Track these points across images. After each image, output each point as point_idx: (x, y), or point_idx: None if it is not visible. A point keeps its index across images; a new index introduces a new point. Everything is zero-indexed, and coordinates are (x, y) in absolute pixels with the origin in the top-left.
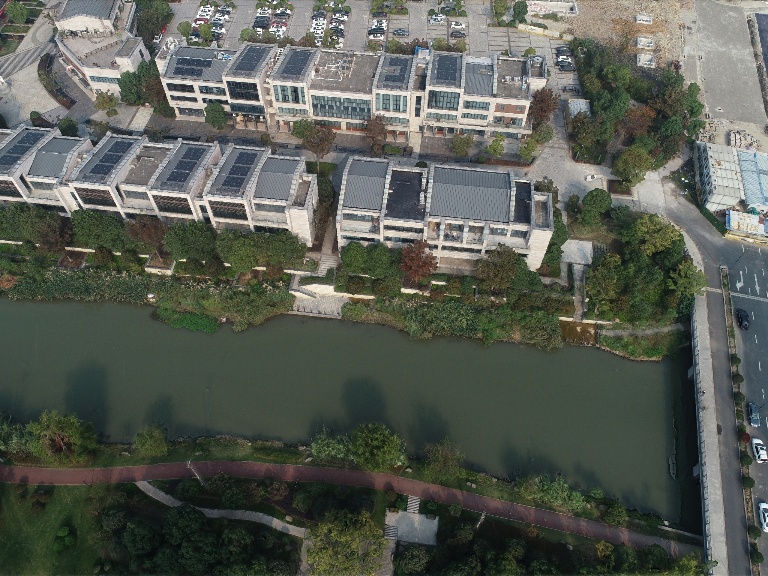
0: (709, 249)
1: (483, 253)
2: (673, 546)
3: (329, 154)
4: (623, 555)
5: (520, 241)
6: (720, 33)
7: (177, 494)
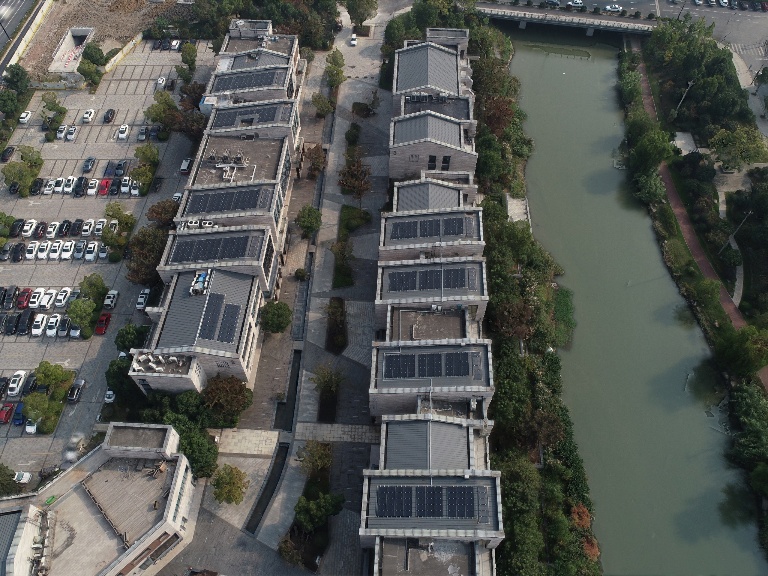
0: None
1: None
2: (635, 50)
3: (325, 214)
4: (663, 54)
5: (460, 62)
6: None
7: (741, 261)
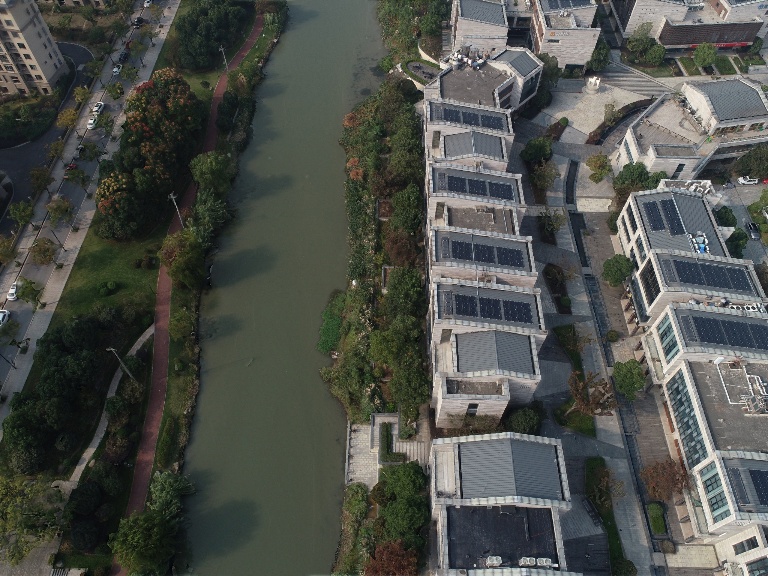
0: None
1: None
2: None
3: (614, 423)
4: None
5: None
6: None
7: None
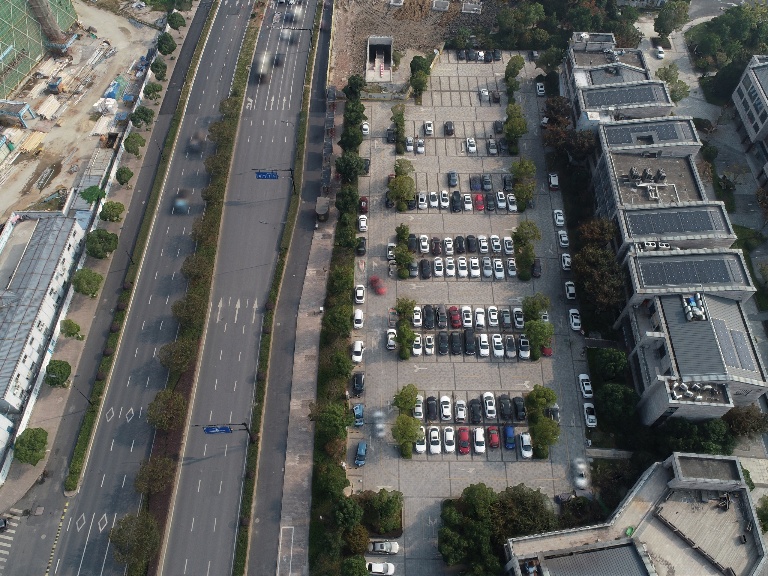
0: (707, 12)
1: None
2: None
3: None
4: None
5: None
6: None
7: None
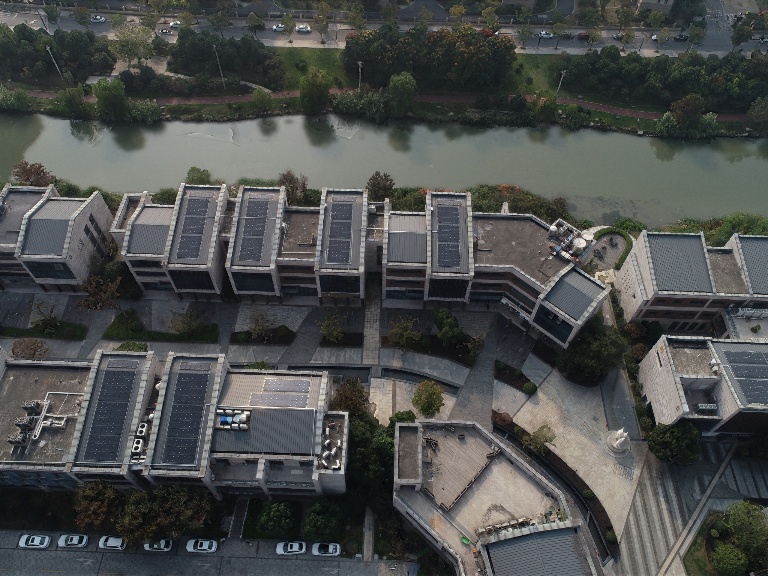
0: None
1: None
2: None
3: None
4: None
5: None
6: None
7: None
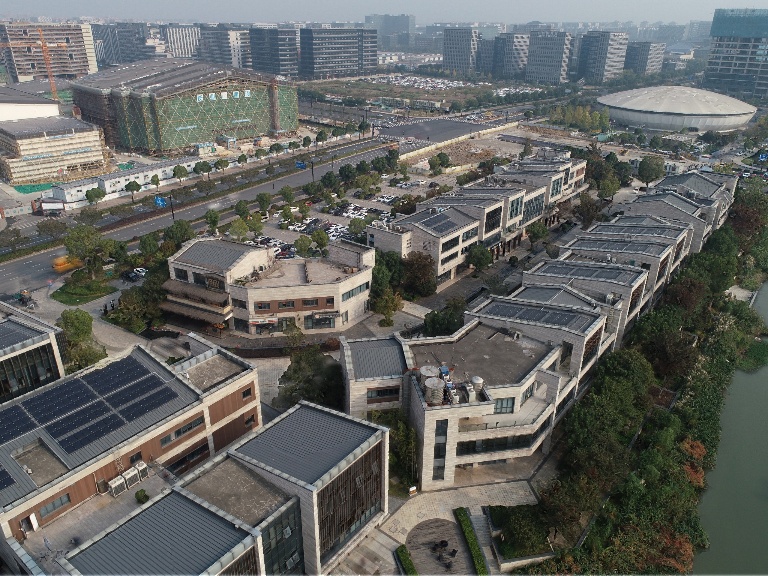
0: None
1: (726, 213)
2: None
3: None
4: None
5: None
6: (507, 146)
7: None
